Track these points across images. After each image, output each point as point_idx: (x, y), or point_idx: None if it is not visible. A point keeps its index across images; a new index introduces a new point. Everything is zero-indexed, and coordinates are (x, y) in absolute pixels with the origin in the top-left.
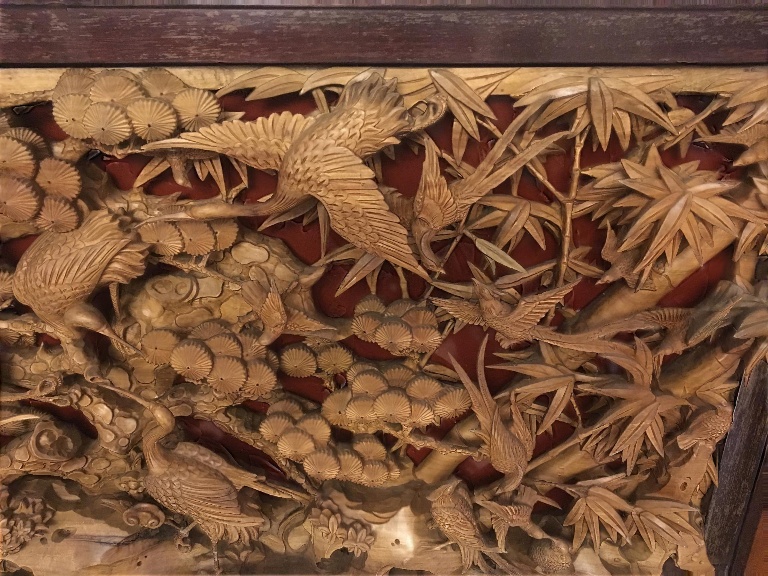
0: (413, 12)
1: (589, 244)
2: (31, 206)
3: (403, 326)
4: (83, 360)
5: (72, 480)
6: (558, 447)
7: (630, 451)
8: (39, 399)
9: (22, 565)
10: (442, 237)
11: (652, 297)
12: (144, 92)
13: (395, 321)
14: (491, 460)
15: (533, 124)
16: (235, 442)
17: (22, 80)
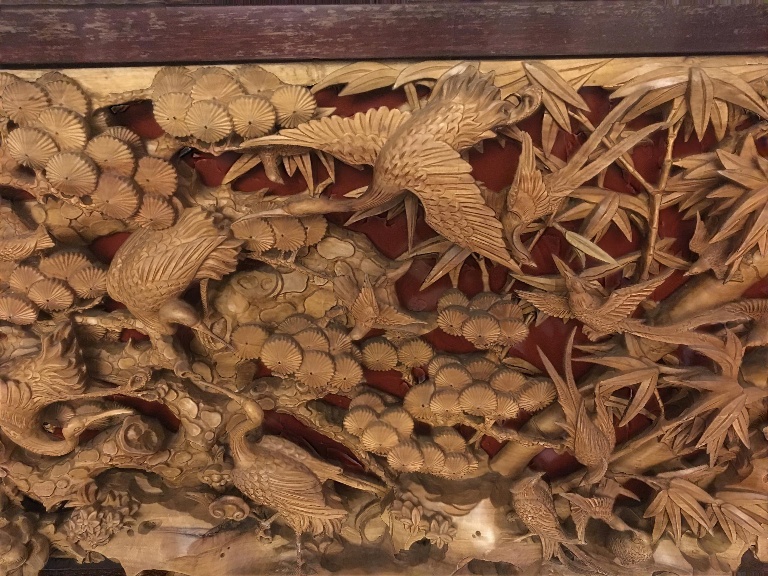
0: (509, 4)
1: (674, 235)
2: (132, 204)
3: (492, 320)
4: (173, 355)
5: (153, 473)
6: (640, 439)
7: (715, 443)
8: (128, 394)
9: (110, 556)
10: (527, 230)
11: (738, 288)
12: (243, 89)
13: (483, 315)
14: (575, 452)
15: (626, 115)
16: (315, 435)
17: (118, 79)
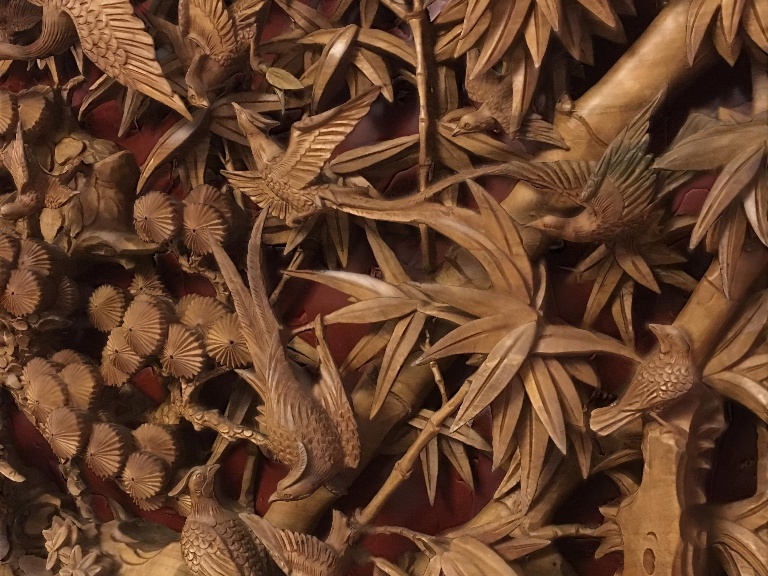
0: None
1: None
2: None
3: (162, 193)
4: None
5: None
6: (408, 449)
7: (506, 441)
8: None
9: None
10: (268, 106)
11: None
12: None
13: None
14: None
15: None
16: (29, 430)
17: None
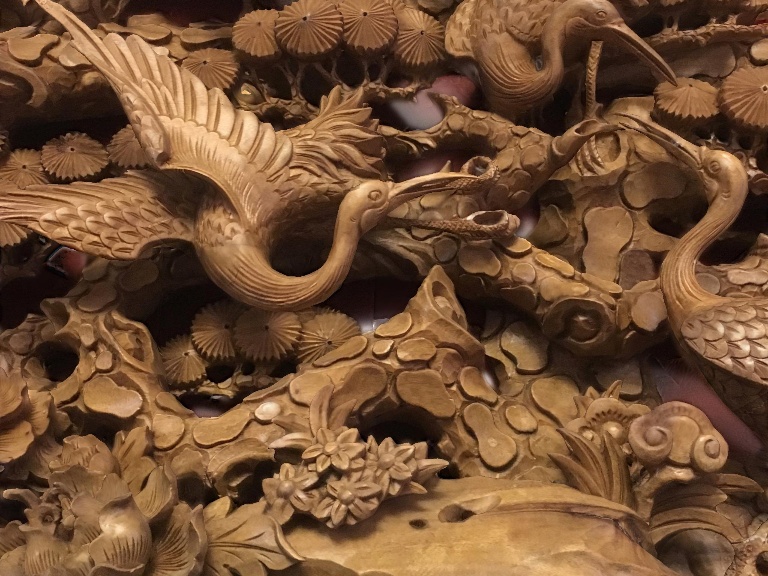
0: None
1: None
2: None
3: None
4: (546, 134)
5: None
6: None
7: None
8: (444, 222)
9: (368, 569)
10: None
11: None
12: None
13: None
14: None
15: None
16: None
17: None
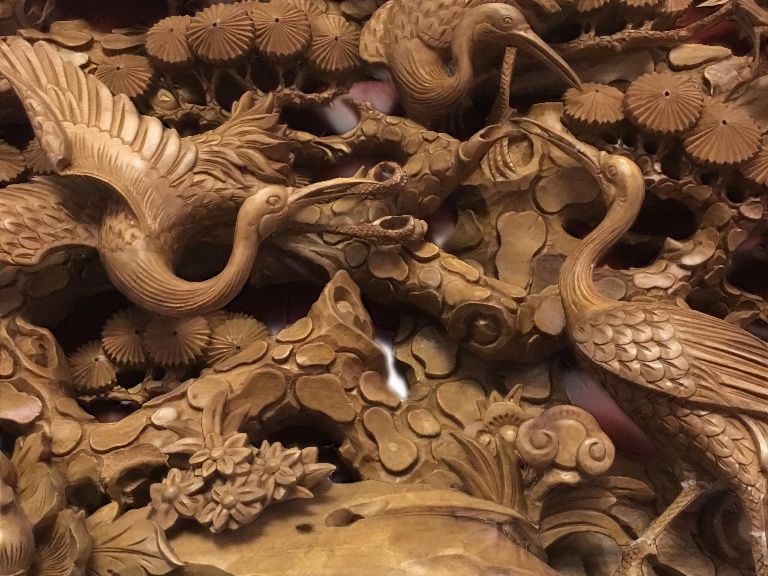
0: None
1: None
2: None
3: None
4: None
5: None
6: None
7: None
8: (352, 227)
9: (248, 573)
10: None
11: None
12: None
13: None
14: None
15: None
16: None
17: None
